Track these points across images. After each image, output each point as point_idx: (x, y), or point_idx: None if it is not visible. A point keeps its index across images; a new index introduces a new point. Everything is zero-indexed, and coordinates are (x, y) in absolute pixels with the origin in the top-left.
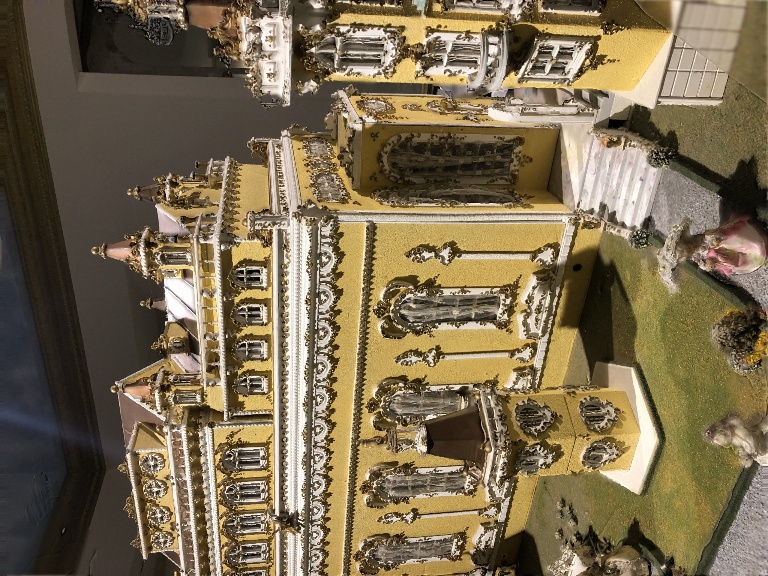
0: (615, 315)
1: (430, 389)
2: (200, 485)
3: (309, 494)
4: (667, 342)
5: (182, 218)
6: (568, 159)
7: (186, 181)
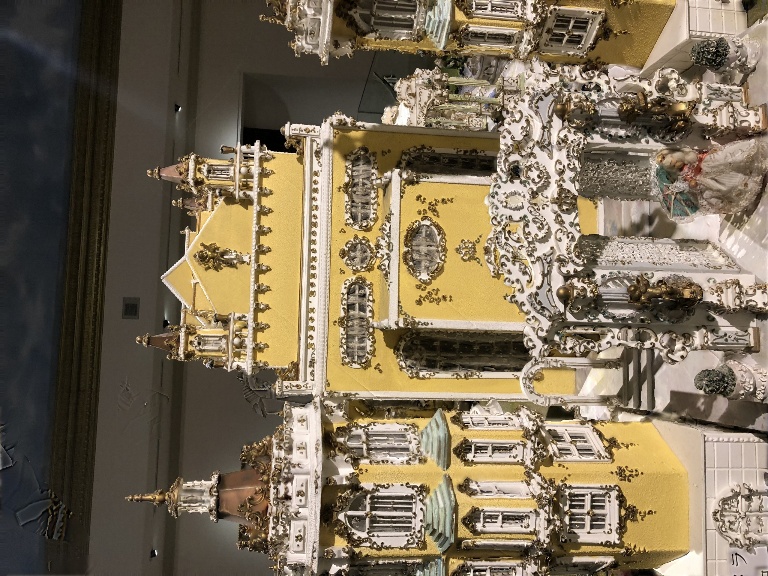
0: None
1: None
2: None
3: None
4: None
5: (215, 321)
6: None
7: (212, 177)
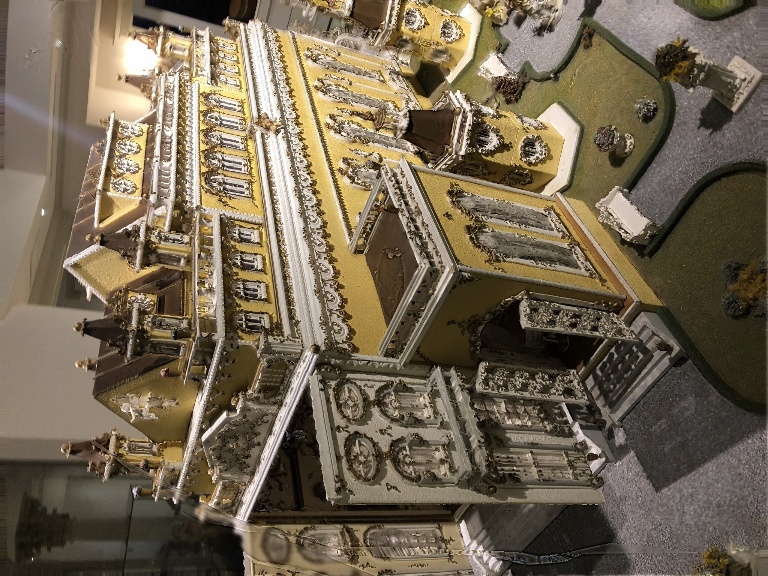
0: None
1: (353, 92)
2: (185, 109)
3: (283, 115)
4: (449, 8)
5: None
6: None
7: None
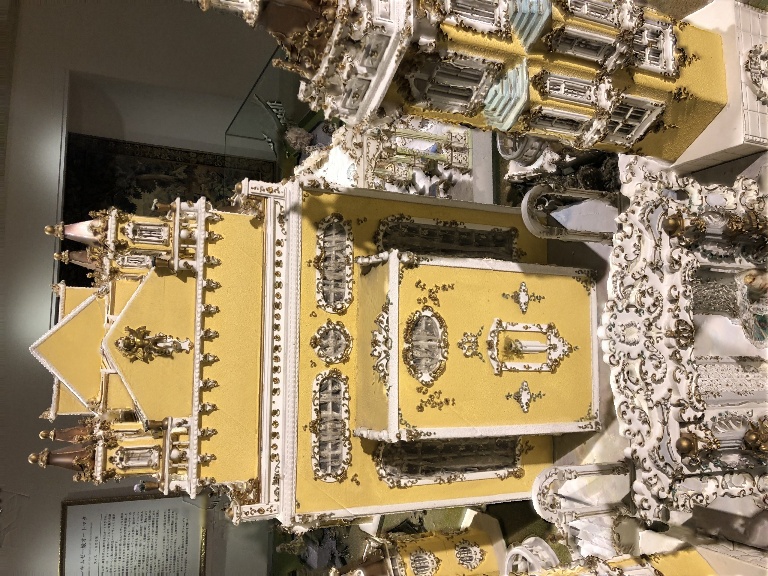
0: (530, 531)
1: None
2: None
3: None
4: None
5: (146, 430)
6: (584, 462)
7: (139, 240)
